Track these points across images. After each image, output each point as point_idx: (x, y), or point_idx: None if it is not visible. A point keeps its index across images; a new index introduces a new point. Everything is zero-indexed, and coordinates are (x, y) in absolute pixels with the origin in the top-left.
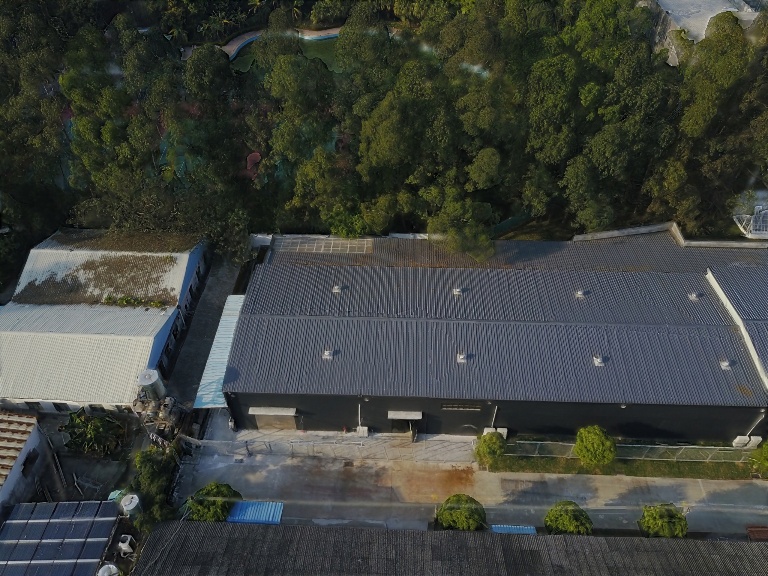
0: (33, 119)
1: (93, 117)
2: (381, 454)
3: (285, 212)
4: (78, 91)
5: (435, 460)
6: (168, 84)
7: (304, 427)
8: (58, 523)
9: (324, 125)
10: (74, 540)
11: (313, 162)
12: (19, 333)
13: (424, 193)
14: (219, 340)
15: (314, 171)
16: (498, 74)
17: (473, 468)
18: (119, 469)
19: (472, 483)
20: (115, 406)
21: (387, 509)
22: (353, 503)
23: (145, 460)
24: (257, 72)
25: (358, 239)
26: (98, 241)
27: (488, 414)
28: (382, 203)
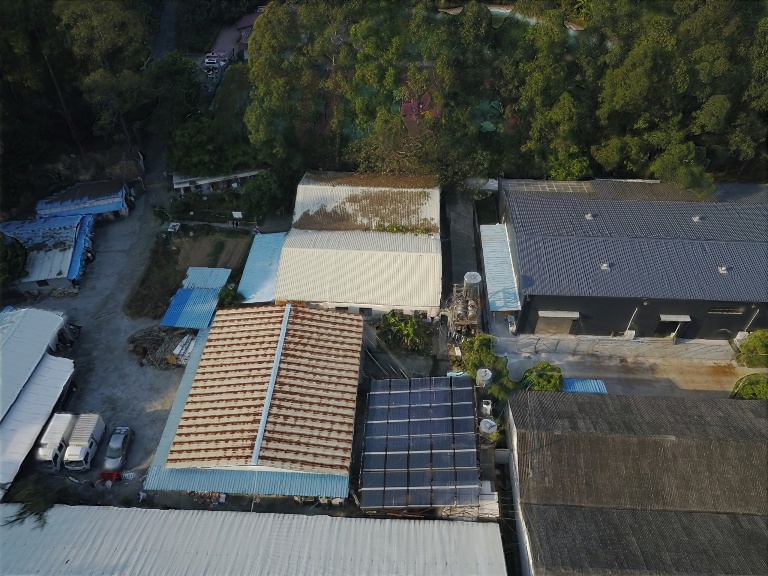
0: (318, 67)
1: (377, 64)
2: (649, 353)
3: (514, 156)
4: (374, 40)
5: (698, 358)
6: (448, 35)
7: (576, 332)
8: (419, 393)
9: (565, 75)
10: (441, 404)
11: (561, 107)
12: (322, 250)
13: (650, 137)
14: (489, 259)
15: (564, 114)
16: (734, 28)
17: (733, 365)
18: (427, 362)
19: (737, 376)
20: (414, 311)
21: (671, 394)
22: (640, 389)
23: (481, 344)
24: (517, 26)
25: (575, 181)
26: (350, 180)
27: (747, 318)
28: (614, 145)
